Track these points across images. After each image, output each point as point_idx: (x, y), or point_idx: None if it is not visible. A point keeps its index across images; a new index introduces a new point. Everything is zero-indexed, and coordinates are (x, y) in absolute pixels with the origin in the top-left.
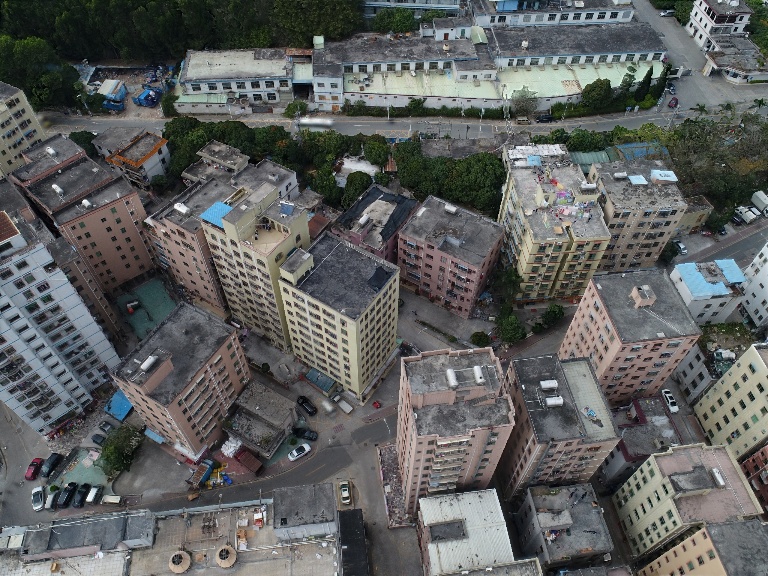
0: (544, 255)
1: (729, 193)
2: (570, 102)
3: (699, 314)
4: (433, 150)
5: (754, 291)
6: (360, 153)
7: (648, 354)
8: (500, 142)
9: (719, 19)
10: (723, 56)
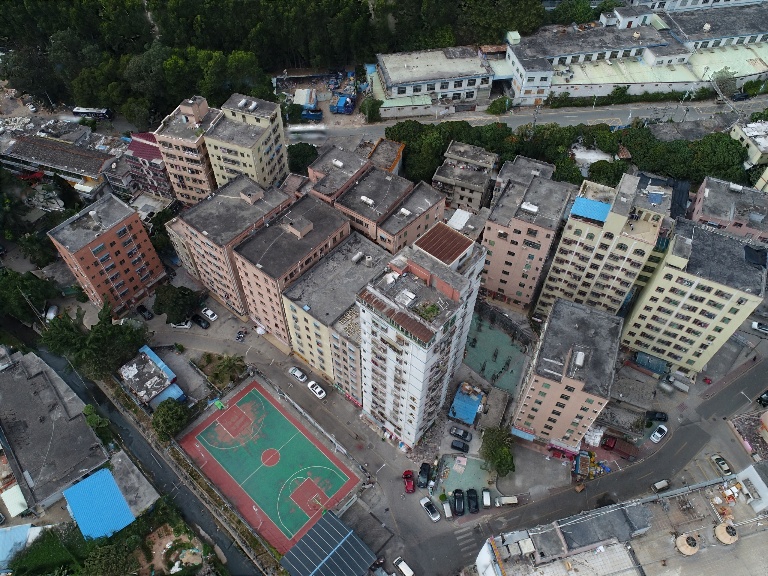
0: None
1: None
2: (759, 80)
3: None
4: (664, 134)
5: None
6: (592, 143)
7: None
8: (723, 122)
9: None
10: None
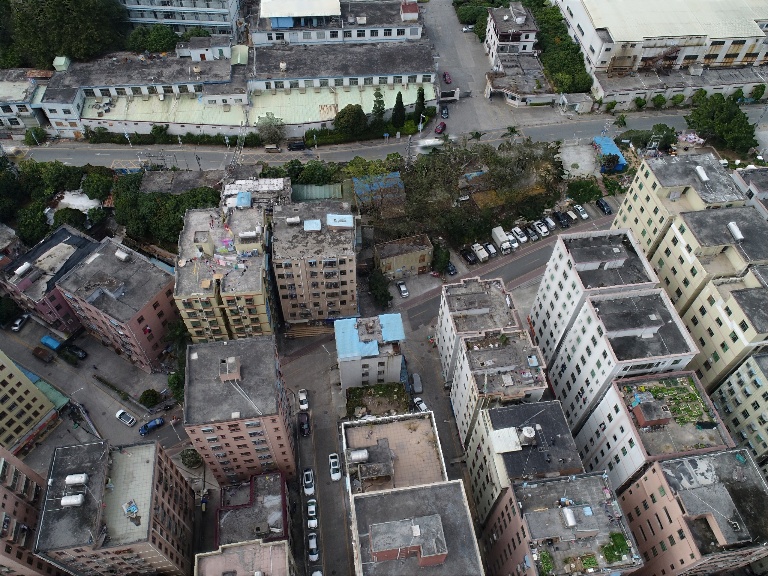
0: (197, 310)
1: (464, 229)
2: (326, 128)
3: (362, 373)
4: (153, 184)
5: (442, 344)
6: (78, 187)
7: (233, 434)
8: None
9: (502, 37)
10: (503, 77)
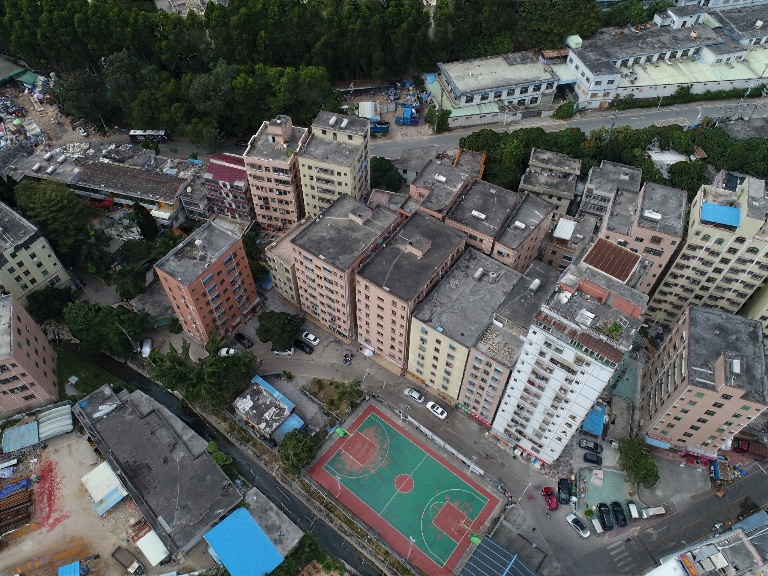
0: None
1: None
2: None
3: None
4: (738, 132)
5: None
6: (668, 144)
7: None
8: None
9: None
10: None
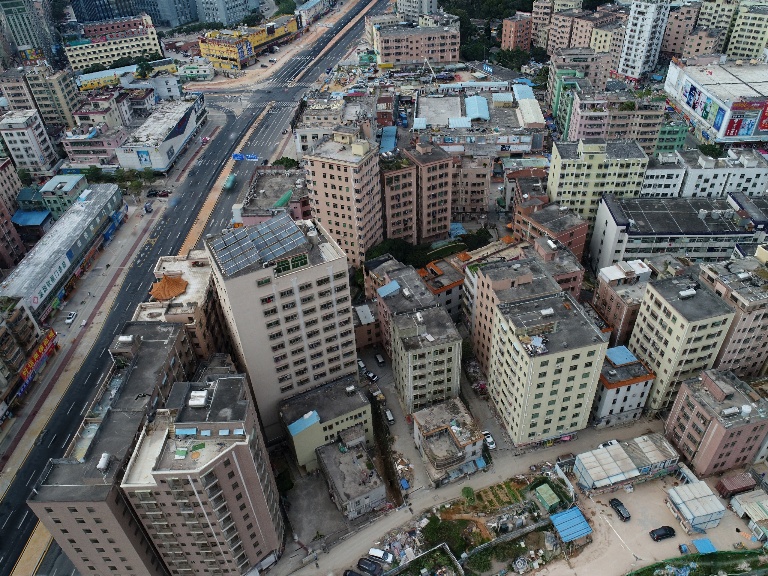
0: None
1: None
2: None
3: None
4: None
5: None
6: None
7: None
8: None
9: None
10: None
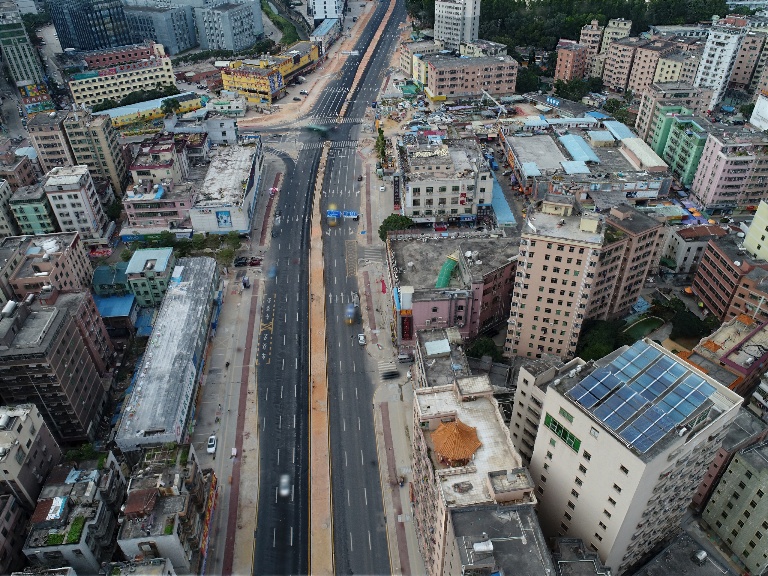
0: None
1: None
2: None
3: None
4: None
5: None
6: None
7: None
8: None
9: None
10: None
